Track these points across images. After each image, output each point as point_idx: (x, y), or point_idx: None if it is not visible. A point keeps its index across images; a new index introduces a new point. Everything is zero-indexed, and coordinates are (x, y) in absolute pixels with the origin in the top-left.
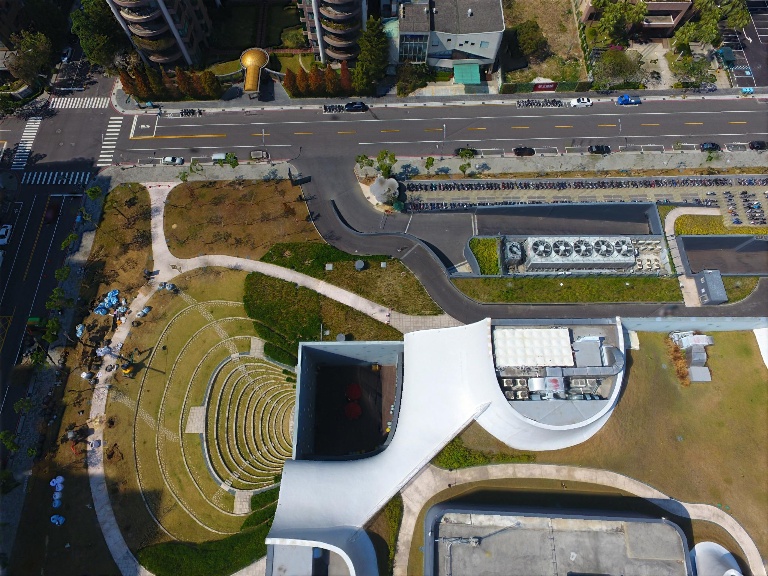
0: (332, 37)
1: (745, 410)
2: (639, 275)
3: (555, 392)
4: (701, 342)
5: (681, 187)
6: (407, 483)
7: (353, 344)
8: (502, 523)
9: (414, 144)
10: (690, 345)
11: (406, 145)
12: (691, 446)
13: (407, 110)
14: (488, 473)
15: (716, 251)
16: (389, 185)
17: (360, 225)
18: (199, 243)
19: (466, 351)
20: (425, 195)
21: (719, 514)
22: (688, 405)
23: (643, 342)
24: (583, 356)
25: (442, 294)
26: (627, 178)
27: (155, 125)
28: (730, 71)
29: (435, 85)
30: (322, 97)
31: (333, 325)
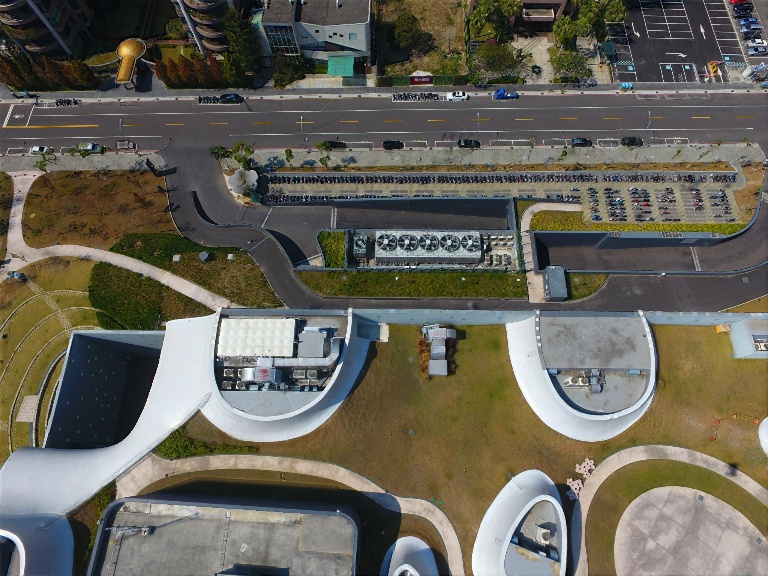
0: (204, 28)
1: (483, 405)
2: (485, 270)
3: (269, 383)
4: (439, 335)
5: (546, 183)
6: (124, 472)
7: (126, 333)
8: (180, 513)
9: (284, 136)
10: (431, 338)
11: (276, 137)
12: (420, 440)
13: (282, 102)
14: (209, 463)
15: (578, 248)
16: (248, 177)
17: (219, 217)
18: (54, 233)
19: (205, 341)
20: (288, 188)
21: (430, 509)
22: (426, 399)
23: (393, 335)
24: (306, 347)
25: (285, 287)
26: (491, 173)
27: (29, 115)
28: (613, 66)
29: (313, 77)
30: (199, 88)
31: (171, 316)
